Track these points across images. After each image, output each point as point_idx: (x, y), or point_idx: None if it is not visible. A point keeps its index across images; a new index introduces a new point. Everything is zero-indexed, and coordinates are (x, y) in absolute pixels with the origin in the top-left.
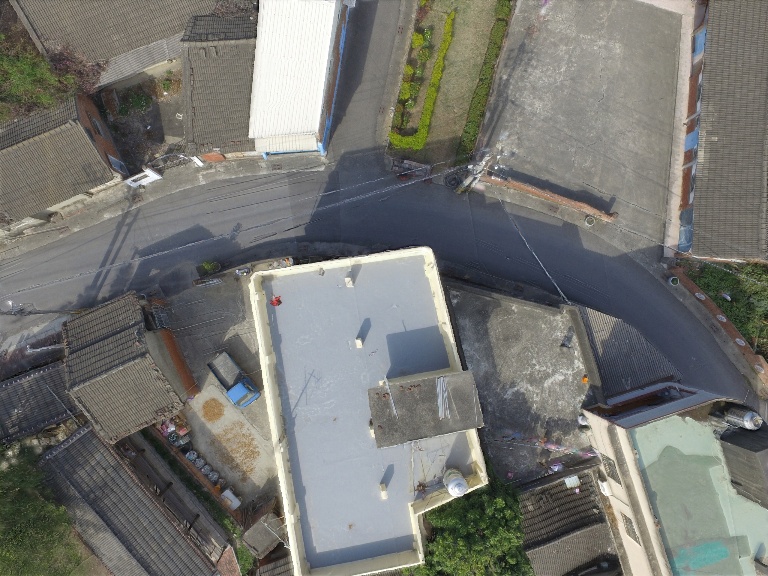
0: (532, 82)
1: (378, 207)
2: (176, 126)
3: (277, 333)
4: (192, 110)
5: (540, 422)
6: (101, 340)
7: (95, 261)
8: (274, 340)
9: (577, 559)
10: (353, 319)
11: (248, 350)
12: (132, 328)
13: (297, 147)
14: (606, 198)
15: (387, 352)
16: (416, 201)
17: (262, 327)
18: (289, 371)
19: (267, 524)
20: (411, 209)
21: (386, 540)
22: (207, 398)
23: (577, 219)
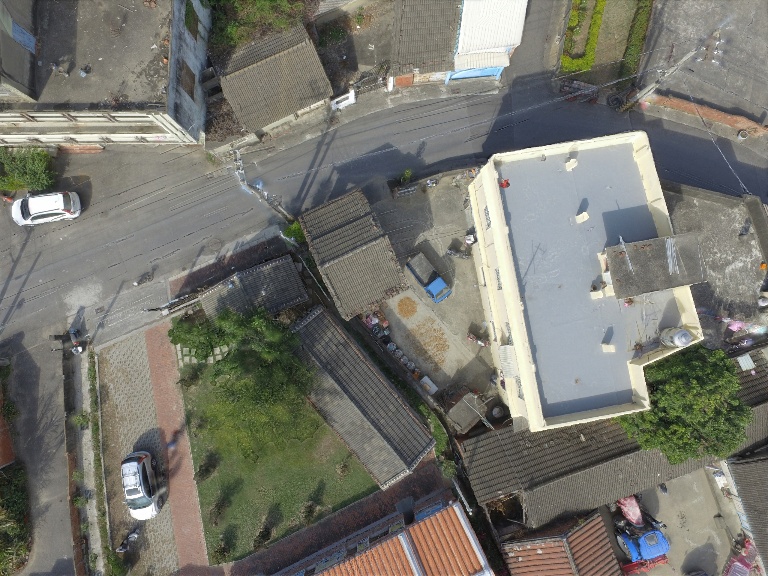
0: (685, 10)
1: (547, 126)
2: (368, 56)
3: (507, 211)
4: (400, 33)
5: (723, 304)
6: (339, 228)
7: (299, 177)
8: (505, 217)
9: (755, 435)
10: (573, 199)
11: (436, 254)
12: (366, 217)
13: (492, 64)
14: (757, 114)
15: (603, 228)
16: (582, 120)
17: (501, 202)
18: (518, 244)
19: (476, 397)
20: (577, 127)
21: (608, 394)
22: (401, 297)
23: (730, 134)
